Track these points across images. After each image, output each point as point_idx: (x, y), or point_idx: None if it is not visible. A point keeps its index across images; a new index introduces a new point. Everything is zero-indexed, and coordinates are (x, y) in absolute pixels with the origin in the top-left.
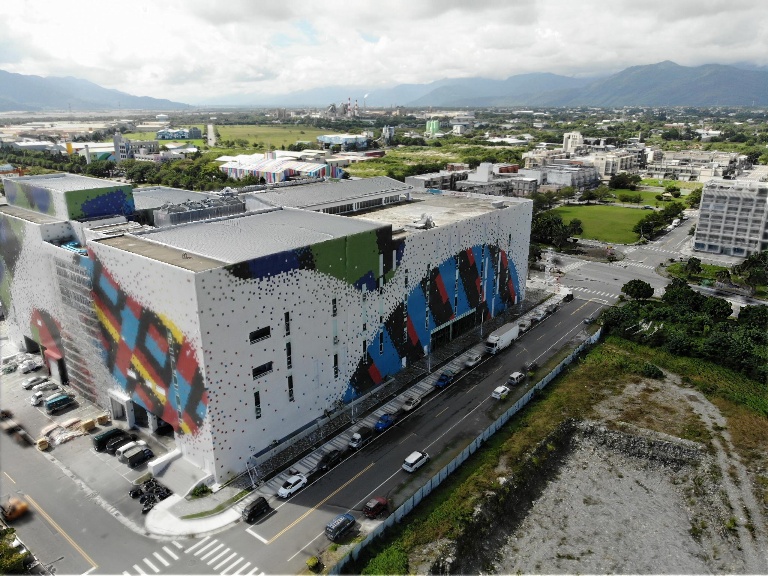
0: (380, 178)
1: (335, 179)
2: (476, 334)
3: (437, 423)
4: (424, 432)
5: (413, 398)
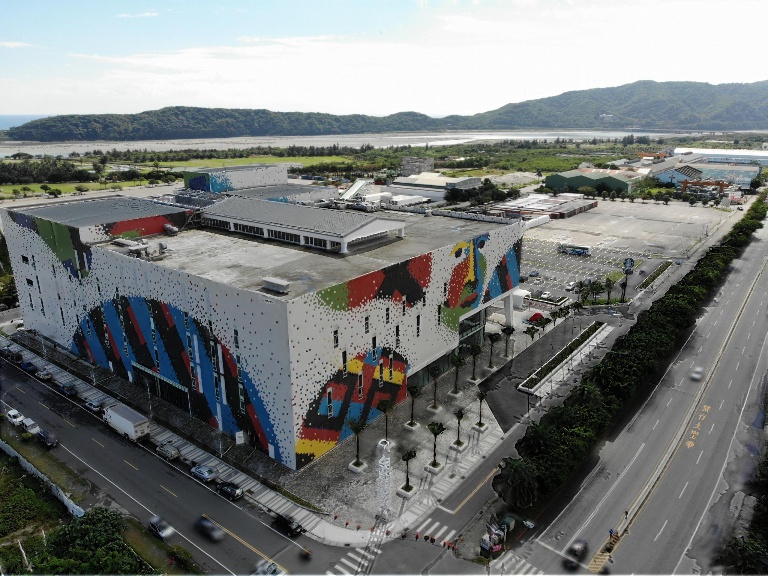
0: (356, 217)
1: (512, 224)
2: (169, 413)
3: (6, 387)
4: (1, 382)
5: (44, 371)
